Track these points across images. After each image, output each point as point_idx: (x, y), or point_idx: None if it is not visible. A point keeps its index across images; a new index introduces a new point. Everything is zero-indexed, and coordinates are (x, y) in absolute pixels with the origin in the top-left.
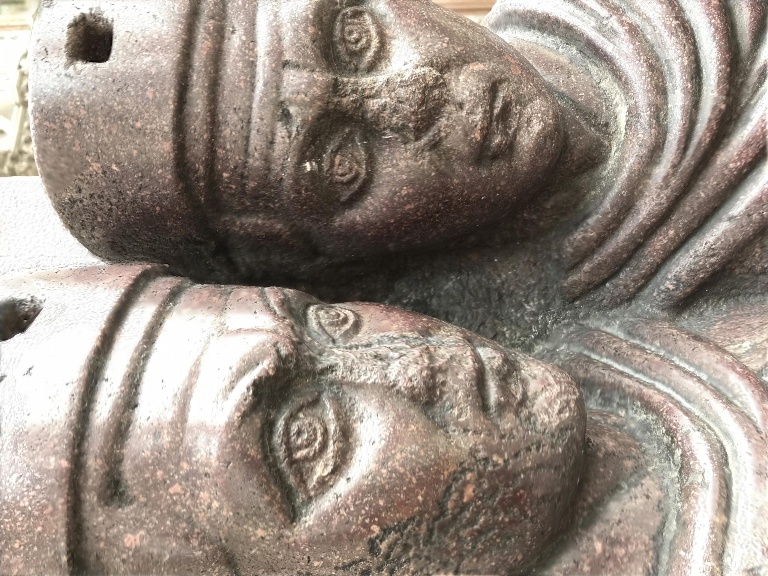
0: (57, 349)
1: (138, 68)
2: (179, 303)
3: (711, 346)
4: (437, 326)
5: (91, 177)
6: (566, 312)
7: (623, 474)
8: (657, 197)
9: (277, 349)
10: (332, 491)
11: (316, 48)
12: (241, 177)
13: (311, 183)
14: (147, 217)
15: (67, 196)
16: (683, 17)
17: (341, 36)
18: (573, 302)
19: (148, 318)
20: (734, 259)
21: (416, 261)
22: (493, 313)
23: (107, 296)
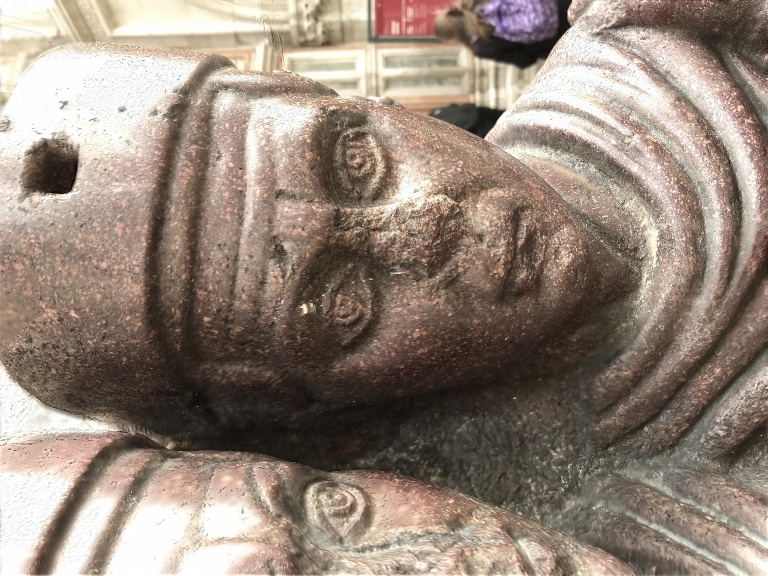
0: None
1: (106, 200)
2: (145, 496)
3: None
4: (468, 511)
5: (45, 325)
6: (599, 459)
7: None
8: (700, 332)
9: (272, 570)
10: None
11: (315, 176)
12: (225, 321)
13: (308, 327)
14: (111, 368)
15: (15, 346)
16: (714, 136)
17: (342, 161)
18: (607, 448)
19: (103, 525)
20: None
21: (423, 400)
22: (515, 461)
23: (51, 495)
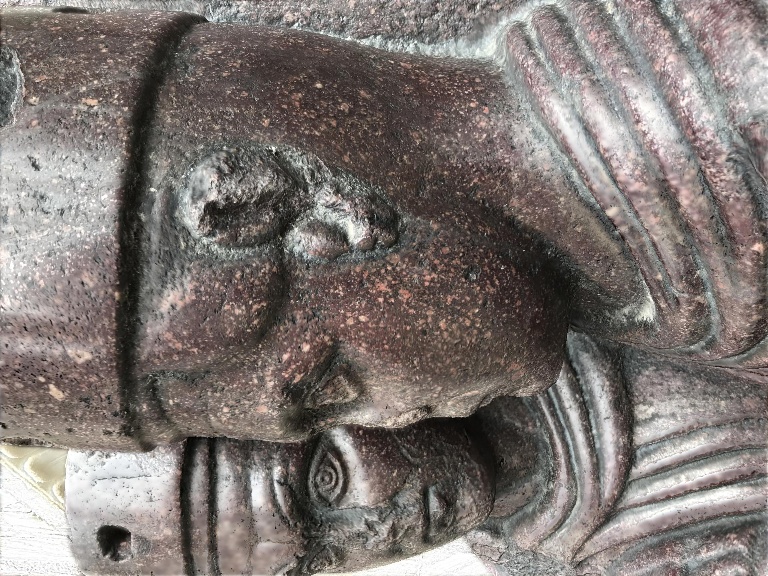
0: (162, 569)
1: None
2: (218, 511)
3: (619, 420)
4: (403, 482)
5: None
6: None
7: (515, 478)
8: None
9: (296, 556)
10: (336, 569)
11: (288, 435)
12: None
13: None
14: None
15: None
16: (763, 331)
17: (313, 407)
18: None
19: (206, 539)
20: None
21: None
22: None
23: (172, 534)
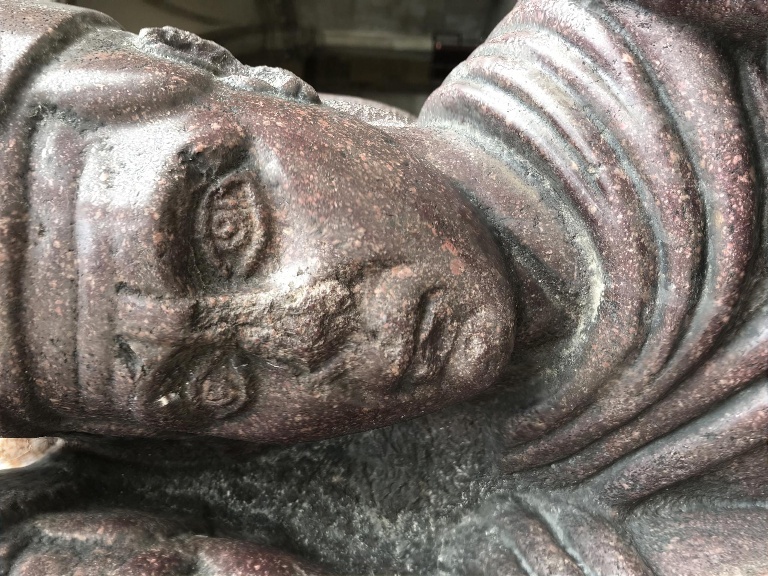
0: None
1: None
2: None
3: None
4: None
5: None
6: (503, 480)
7: None
8: (625, 402)
9: None
10: None
11: (165, 265)
12: (75, 402)
13: (171, 413)
14: None
15: None
16: (695, 189)
17: (207, 232)
18: (512, 473)
19: None
20: (705, 471)
21: None
22: (418, 473)
23: None
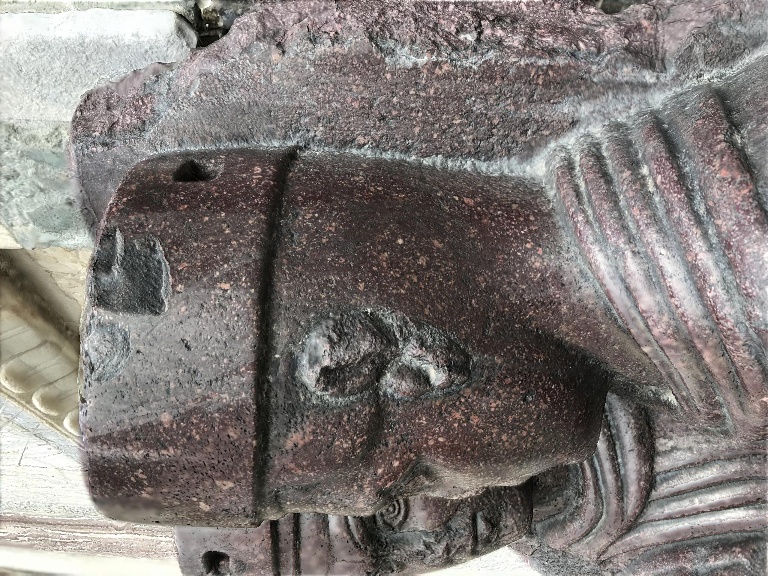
0: None
1: None
2: (301, 539)
3: (642, 452)
4: (455, 510)
5: None
6: None
7: None
8: None
9: (366, 572)
10: None
11: None
12: None
13: None
14: None
15: None
16: None
17: None
18: None
19: (291, 560)
20: None
21: None
22: None
23: (264, 558)
